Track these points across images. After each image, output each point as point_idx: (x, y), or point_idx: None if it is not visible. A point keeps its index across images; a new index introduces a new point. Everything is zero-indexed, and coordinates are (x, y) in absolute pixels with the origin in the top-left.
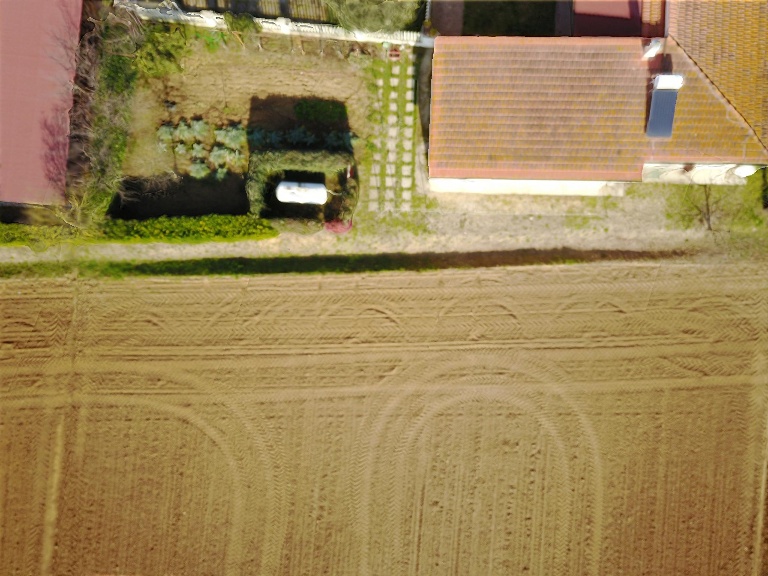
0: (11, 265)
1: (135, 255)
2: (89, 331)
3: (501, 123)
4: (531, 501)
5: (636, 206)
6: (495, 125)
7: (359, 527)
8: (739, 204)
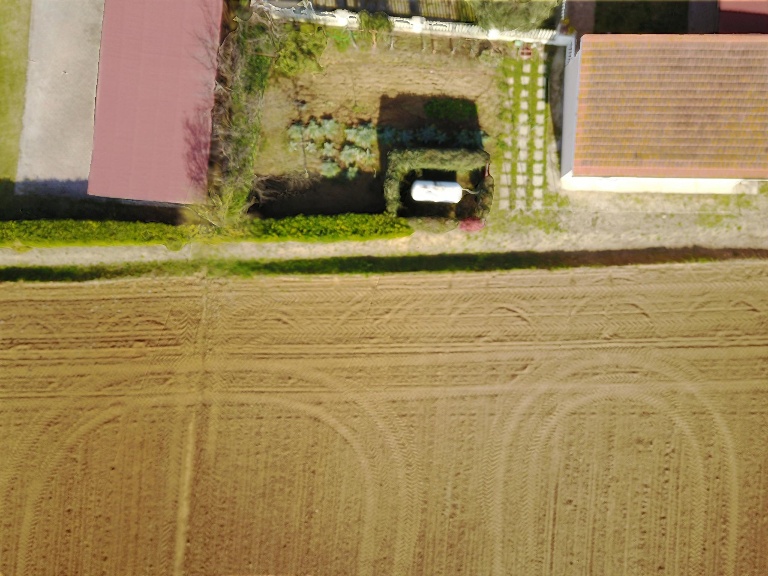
0: (141, 264)
1: (264, 254)
2: (219, 329)
3: (647, 121)
4: (666, 500)
5: None
6: (641, 123)
7: (492, 525)
8: None
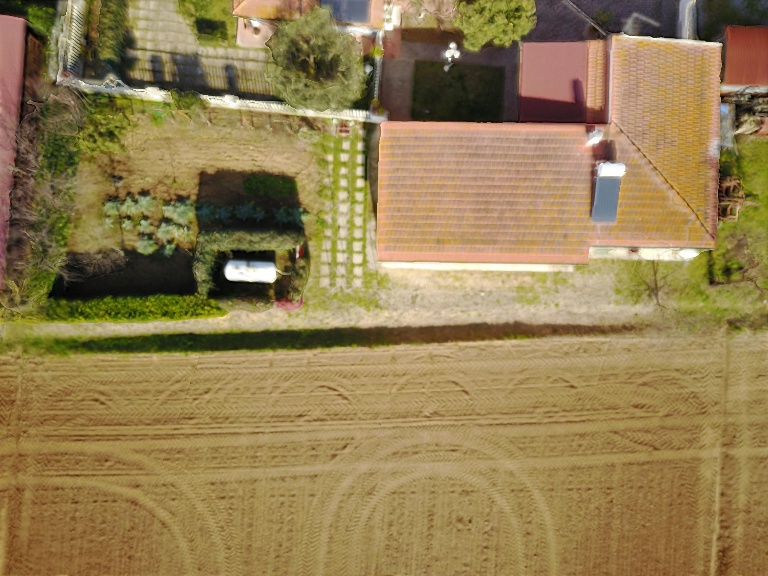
0: None
1: (82, 332)
2: (34, 411)
3: (448, 207)
4: None
5: (586, 281)
6: (442, 209)
7: None
8: (686, 279)
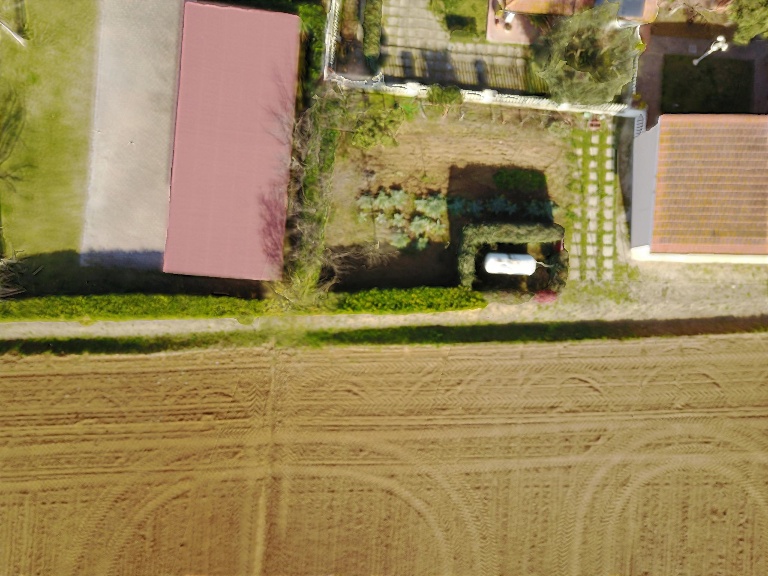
0: (208, 335)
1: (333, 324)
2: (288, 401)
3: (725, 199)
4: (740, 571)
5: None
6: (719, 201)
7: None
8: None
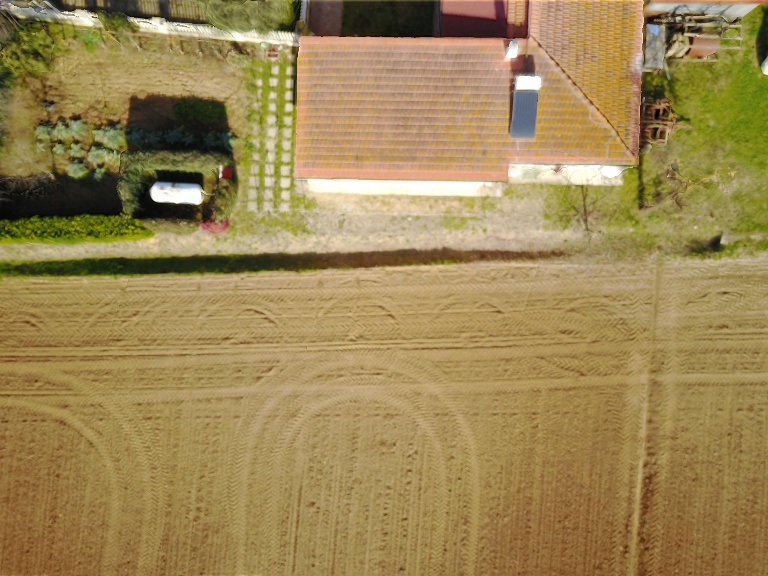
0: None
1: (14, 255)
2: None
3: (367, 123)
4: (408, 501)
5: (514, 206)
6: (361, 125)
7: (236, 528)
8: (615, 205)
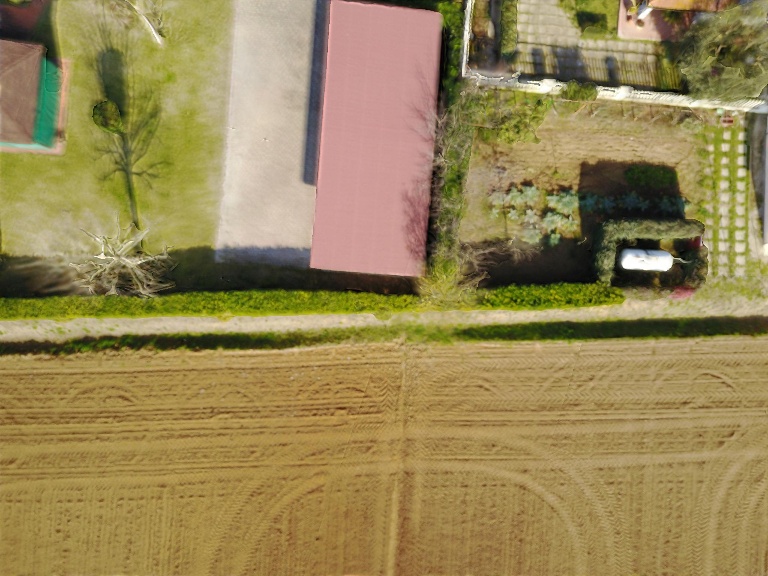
0: (339, 330)
1: (463, 320)
2: (419, 396)
3: None
4: None
5: None
6: None
7: None
8: None
